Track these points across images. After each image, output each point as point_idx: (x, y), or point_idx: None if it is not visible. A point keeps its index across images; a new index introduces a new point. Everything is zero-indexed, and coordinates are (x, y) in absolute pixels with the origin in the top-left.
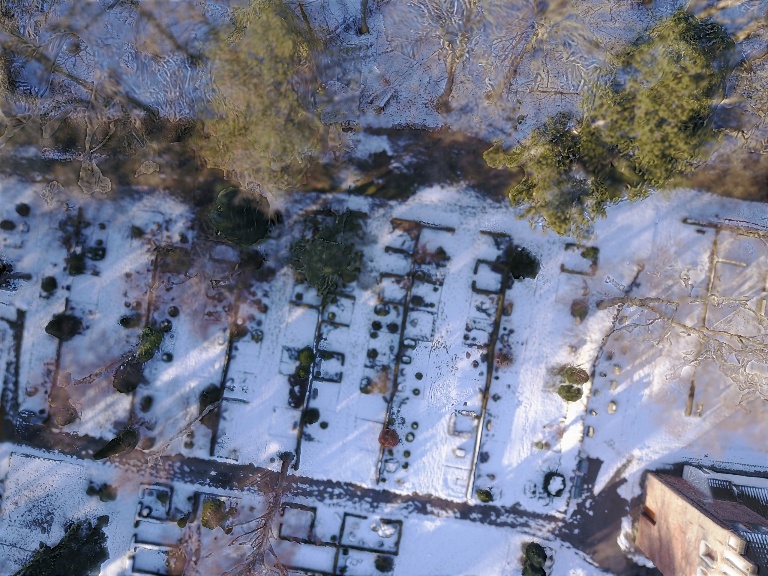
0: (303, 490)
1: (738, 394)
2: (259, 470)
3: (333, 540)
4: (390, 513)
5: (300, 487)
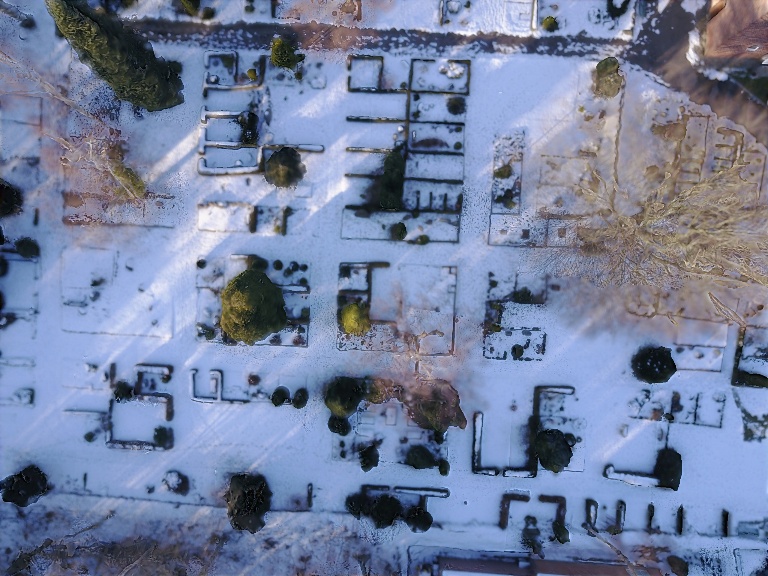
0: (368, 42)
1: None
2: (322, 26)
3: (403, 84)
4: (457, 55)
5: (364, 39)
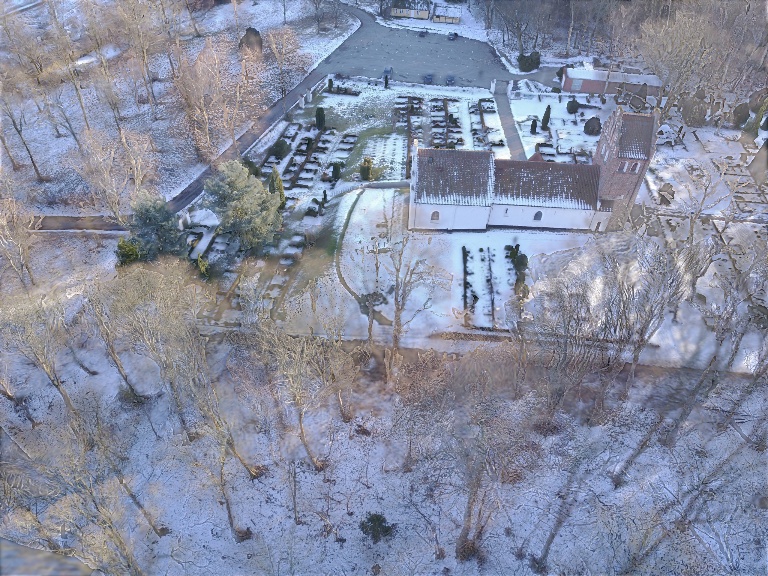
0: None
1: None
2: None
3: None
4: None
5: None
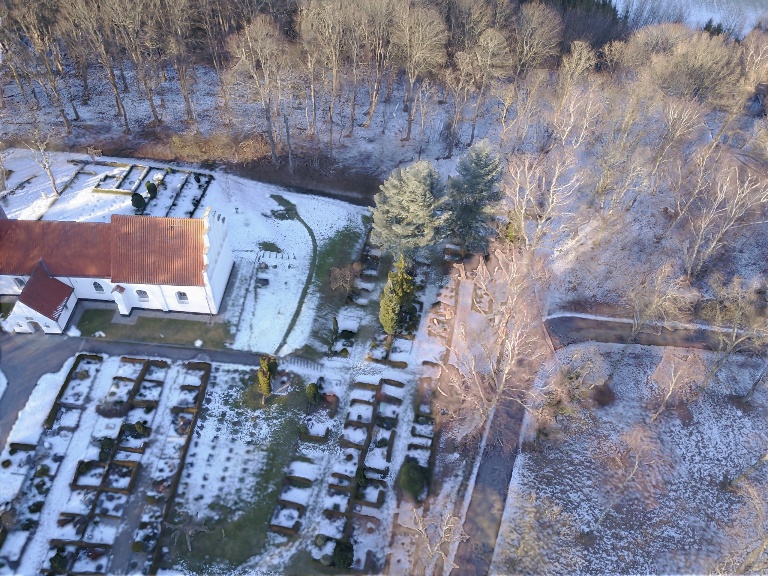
0: None
1: (70, 220)
2: None
3: None
4: None
5: None
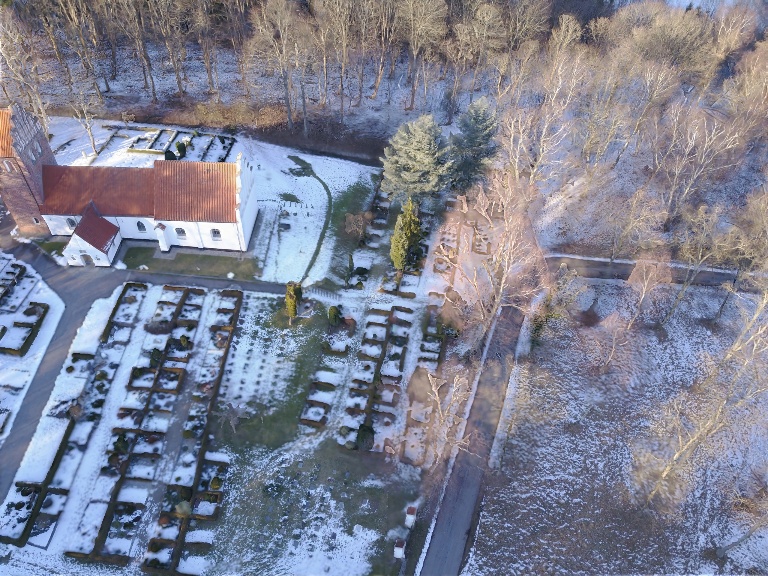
0: None
1: None
2: None
3: None
4: None
5: None
